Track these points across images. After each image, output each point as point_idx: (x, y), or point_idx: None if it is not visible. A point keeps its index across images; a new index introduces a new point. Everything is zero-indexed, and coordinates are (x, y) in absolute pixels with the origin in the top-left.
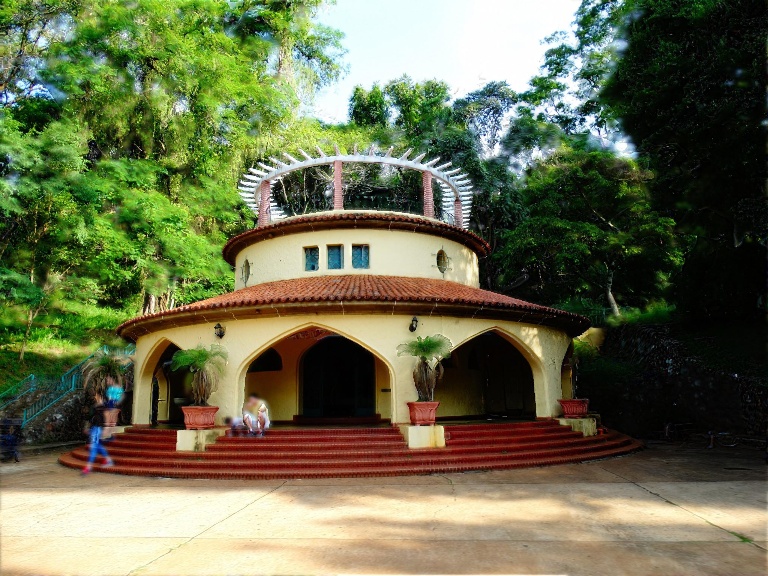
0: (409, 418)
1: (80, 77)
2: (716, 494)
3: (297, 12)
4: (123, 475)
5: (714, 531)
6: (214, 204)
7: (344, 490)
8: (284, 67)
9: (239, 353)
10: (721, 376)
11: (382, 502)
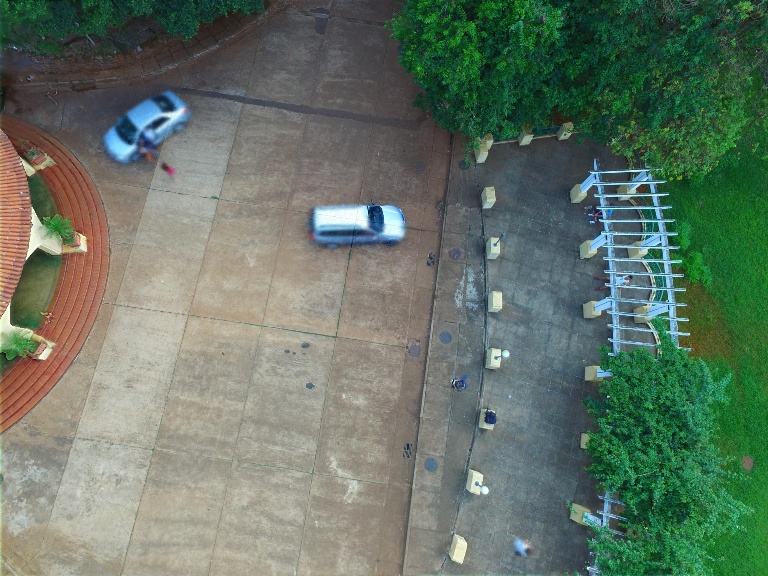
0: (60, 246)
1: None
2: (174, 177)
3: None
4: (60, 381)
5: (210, 200)
6: None
7: (134, 281)
8: None
9: (5, 325)
10: (6, 51)
11: (158, 269)
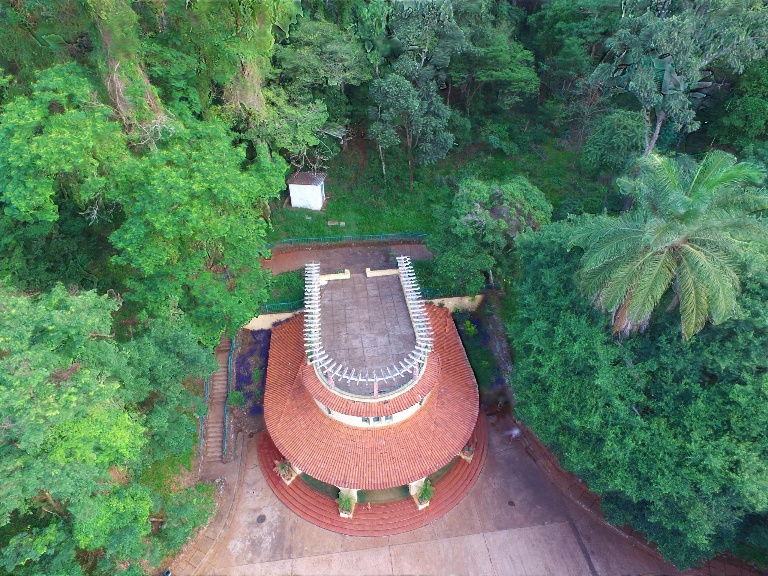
0: None
1: (153, 267)
2: None
3: (257, 27)
4: (329, 531)
5: None
6: (243, 258)
7: (410, 552)
8: (248, 71)
9: None
10: None
11: (425, 568)
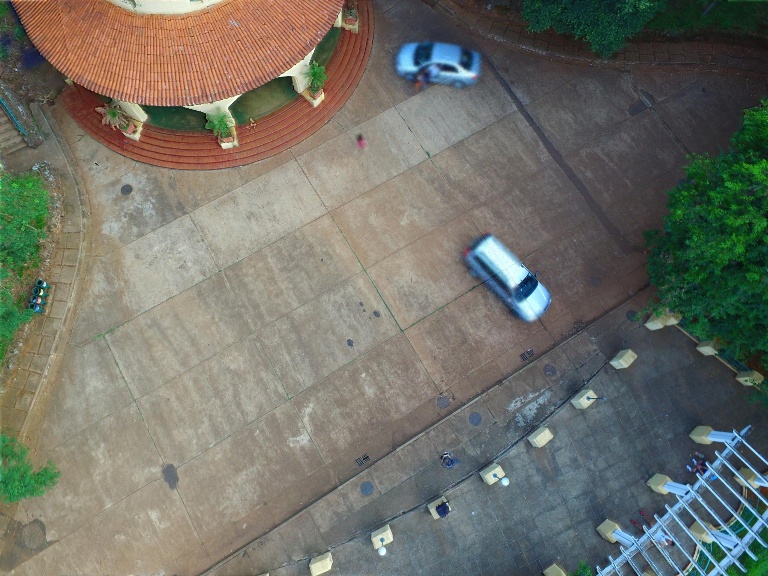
0: (304, 88)
1: None
2: (418, 114)
3: None
4: (217, 170)
5: (423, 153)
6: None
7: (321, 155)
8: None
9: (226, 104)
10: None
11: (343, 164)
